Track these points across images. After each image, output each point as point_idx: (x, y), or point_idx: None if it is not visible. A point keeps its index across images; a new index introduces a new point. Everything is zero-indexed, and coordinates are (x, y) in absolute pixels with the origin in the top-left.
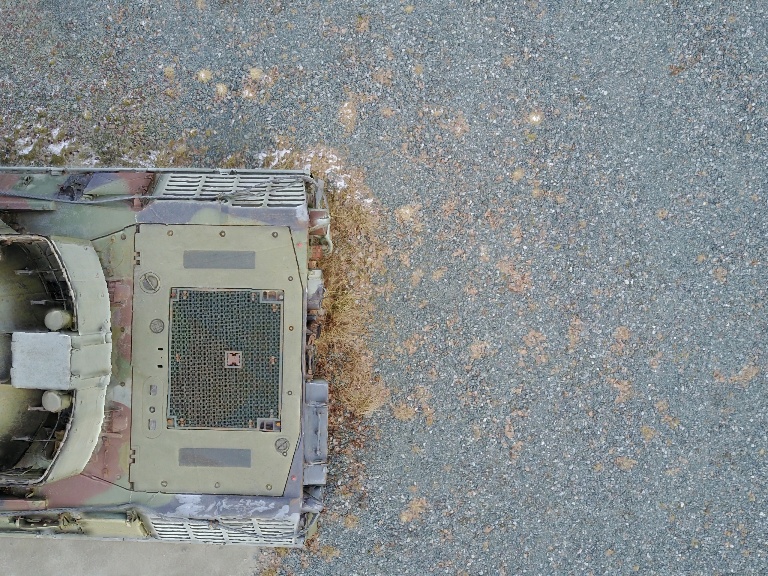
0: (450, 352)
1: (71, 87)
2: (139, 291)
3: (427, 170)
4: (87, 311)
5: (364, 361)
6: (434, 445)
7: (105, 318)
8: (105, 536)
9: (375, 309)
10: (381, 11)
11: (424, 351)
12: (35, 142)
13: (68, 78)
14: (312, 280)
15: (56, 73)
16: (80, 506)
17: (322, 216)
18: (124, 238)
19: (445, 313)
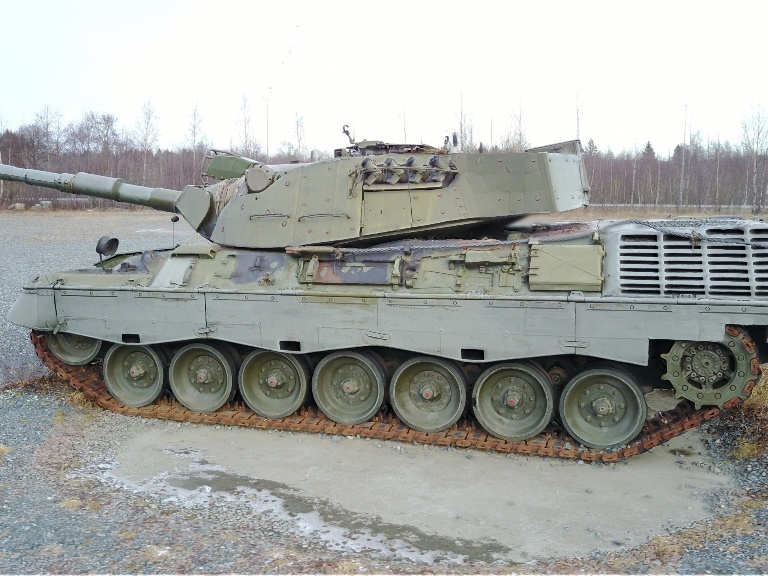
0: None
1: None
2: None
3: None
4: None
5: None
6: None
7: None
8: (552, 279)
9: None
10: None
11: None
12: None
13: None
14: None
15: None
16: None
17: None
18: None
19: None
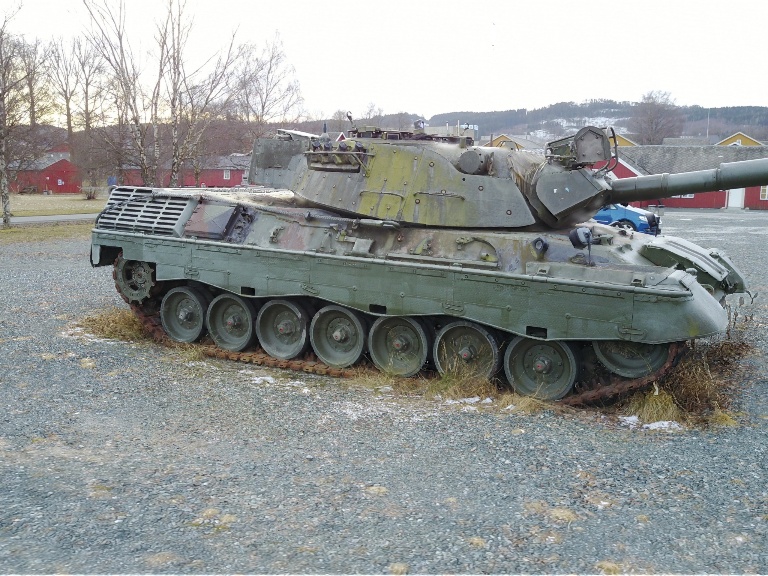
0: None
1: None
2: None
3: None
4: None
5: None
6: None
7: None
8: None
9: None
10: None
11: None
12: None
13: None
14: None
15: None
16: None
17: None
18: None
19: None
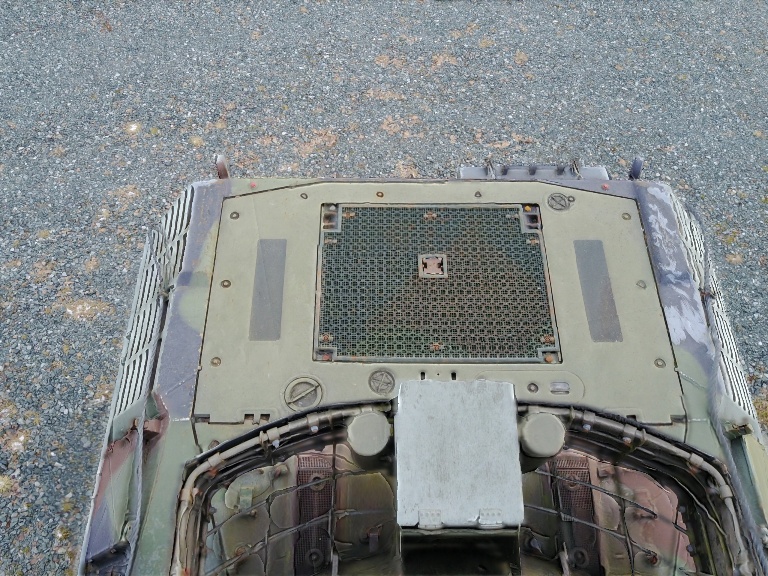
0: None
1: None
2: None
3: None
4: None
5: None
6: None
7: None
8: None
9: None
10: None
11: None
12: None
13: None
14: None
15: None
16: None
17: None
18: None
19: None
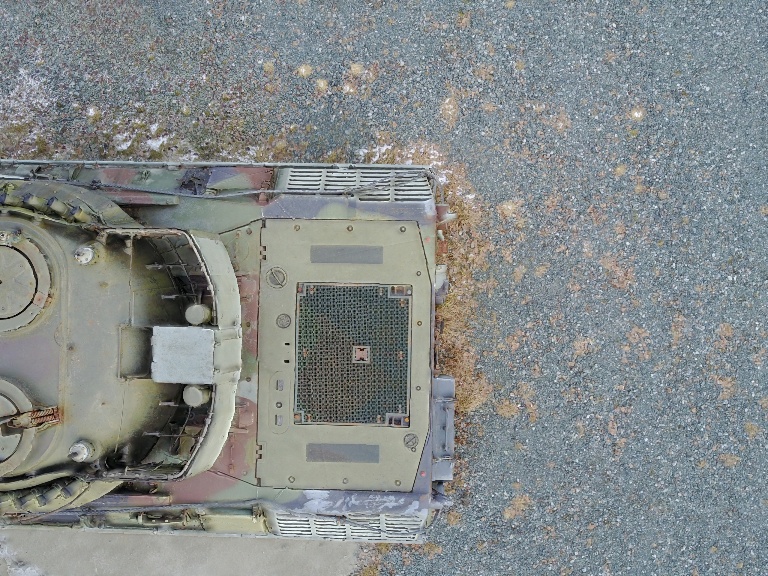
0: (553, 348)
1: (170, 82)
2: (265, 286)
3: (529, 166)
4: (224, 305)
5: (466, 357)
6: (537, 442)
7: (237, 313)
8: (225, 532)
9: (477, 305)
10: (482, 6)
11: (527, 347)
12: (133, 137)
13: (167, 73)
14: (437, 275)
15: (155, 68)
16: (205, 502)
17: (445, 211)
18: (250, 233)
19: (548, 309)
